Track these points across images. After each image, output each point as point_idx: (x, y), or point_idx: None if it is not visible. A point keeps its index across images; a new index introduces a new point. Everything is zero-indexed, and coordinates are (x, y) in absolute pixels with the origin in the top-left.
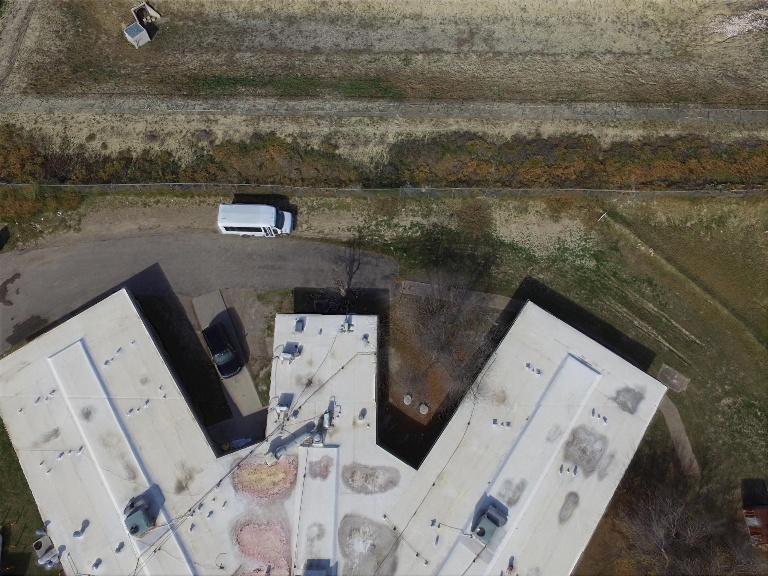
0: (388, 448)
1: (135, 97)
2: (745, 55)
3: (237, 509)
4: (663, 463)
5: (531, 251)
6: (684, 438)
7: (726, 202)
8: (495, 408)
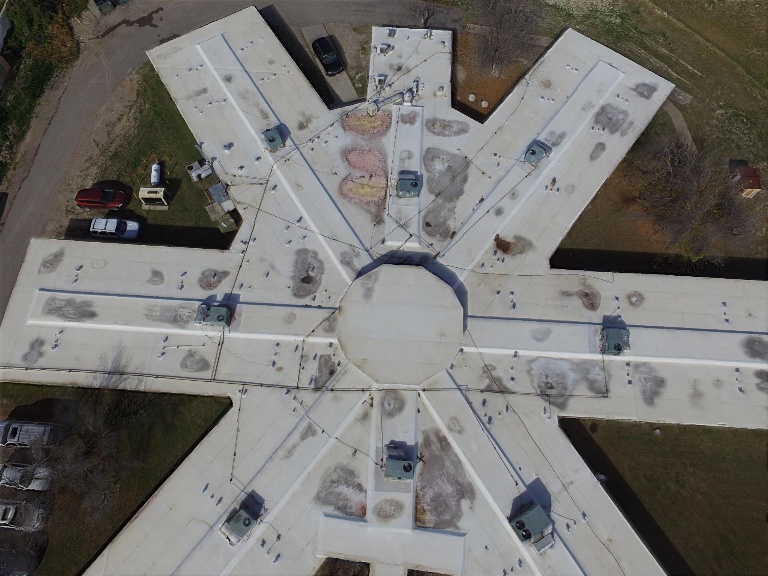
0: None
1: None
2: None
3: (346, 141)
4: None
5: (570, 11)
6: (686, 132)
7: None
8: (543, 90)
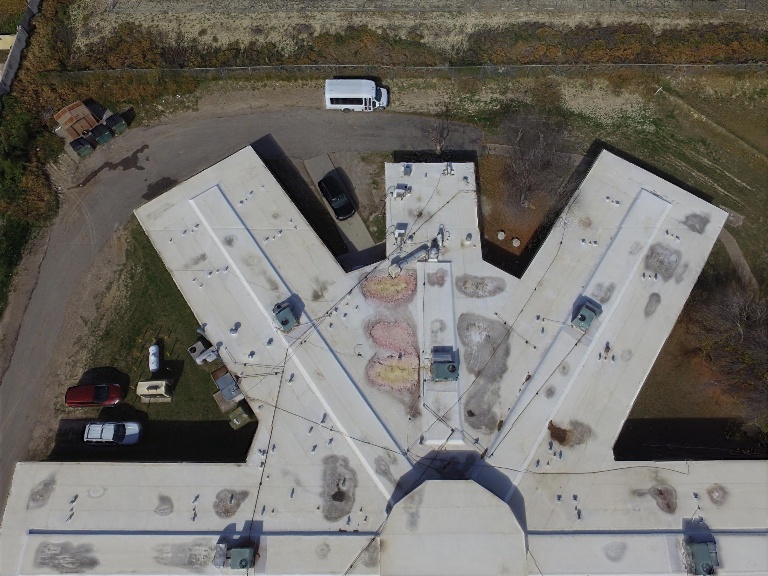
0: (493, 263)
1: None
2: None
3: (368, 311)
4: (726, 281)
5: (598, 119)
6: (743, 261)
7: (765, 77)
8: (583, 231)
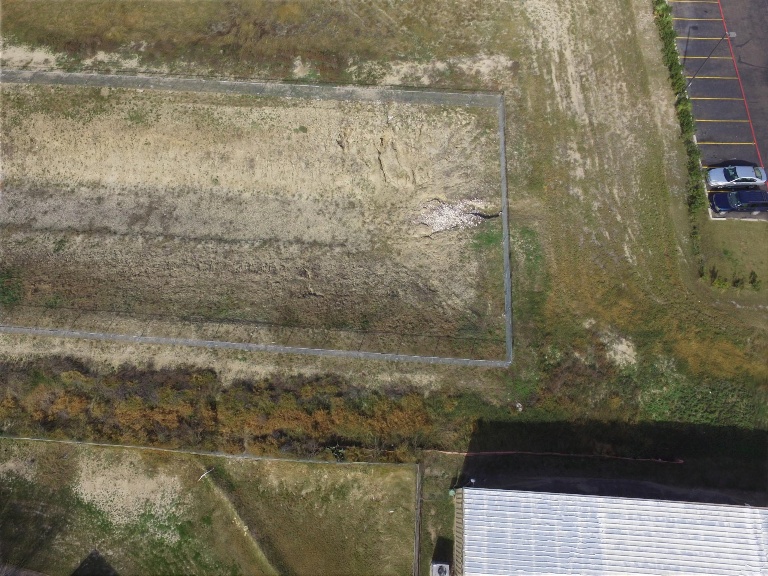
0: None
1: None
2: (443, 259)
3: None
4: None
5: (109, 517)
6: None
7: (351, 468)
8: None
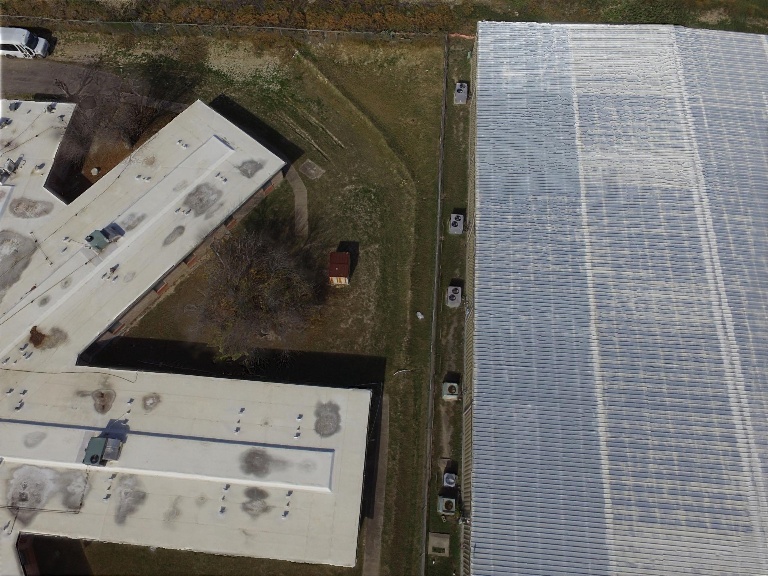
0: (52, 190)
1: None
2: None
3: None
4: (281, 226)
5: (231, 77)
6: (304, 210)
7: (399, 47)
8: (143, 168)
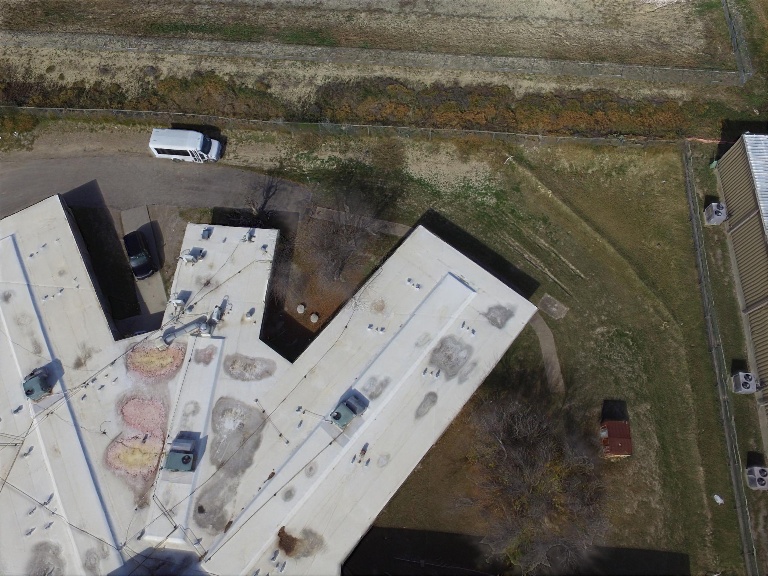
0: (269, 343)
1: (95, 36)
2: (670, 23)
3: (126, 385)
4: (531, 380)
5: (437, 187)
6: (555, 360)
7: (628, 152)
8: (373, 315)
